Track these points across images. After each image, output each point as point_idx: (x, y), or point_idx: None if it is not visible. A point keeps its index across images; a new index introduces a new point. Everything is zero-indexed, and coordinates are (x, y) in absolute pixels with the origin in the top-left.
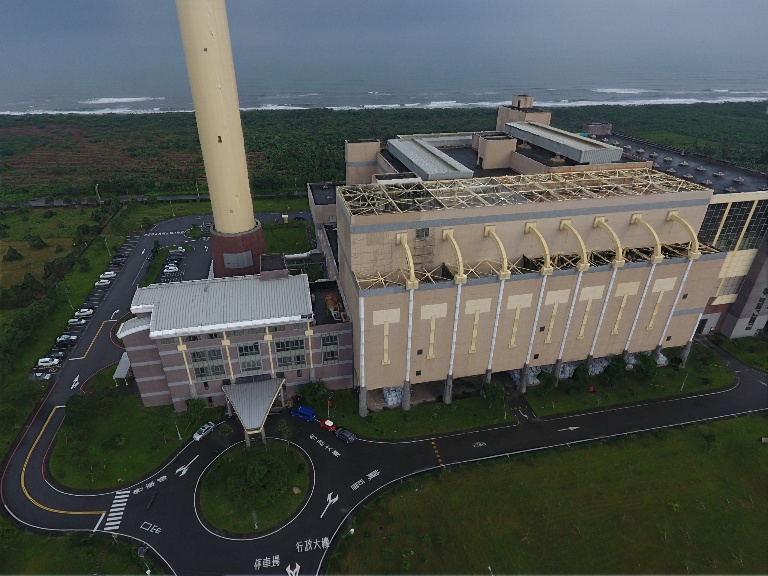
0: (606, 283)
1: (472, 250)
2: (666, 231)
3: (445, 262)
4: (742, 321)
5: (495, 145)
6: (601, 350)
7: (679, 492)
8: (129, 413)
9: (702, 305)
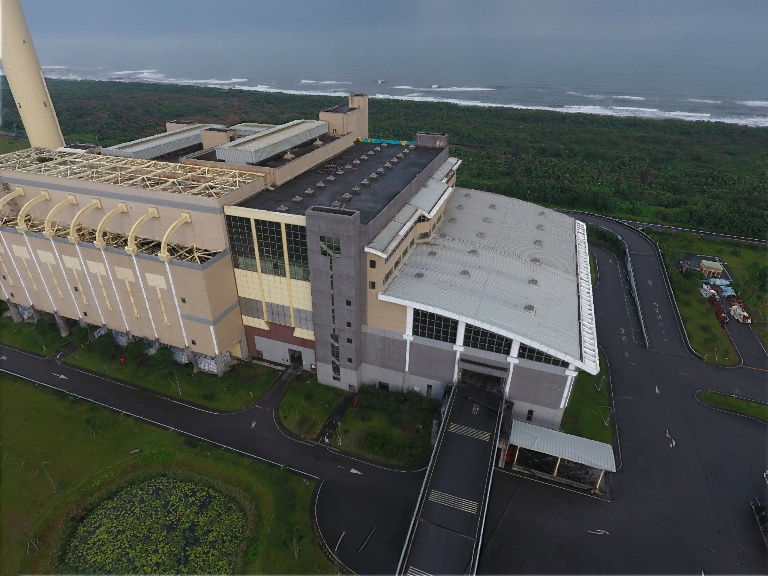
0: (103, 262)
1: (43, 209)
2: (190, 233)
3: (31, 214)
4: (322, 366)
5: (208, 135)
6: (136, 329)
7: (19, 442)
8: None
9: (208, 317)
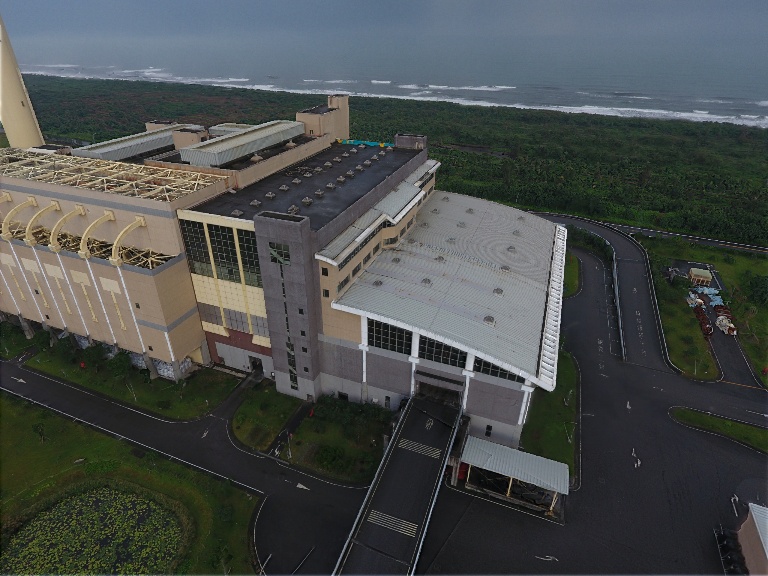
0: (59, 265)
1: (6, 210)
2: (146, 237)
3: None
4: (280, 374)
5: (180, 136)
6: (95, 334)
7: None
8: None
9: (162, 323)
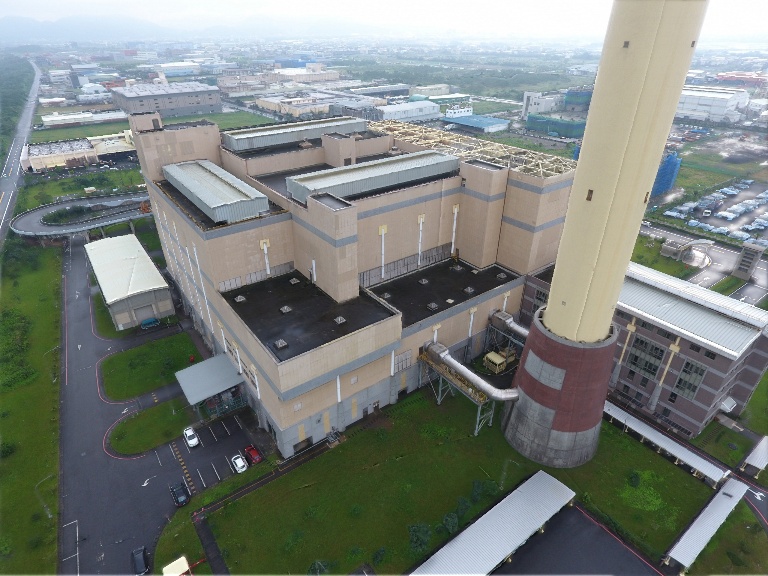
0: None
1: None
2: None
3: None
4: None
5: None
6: None
7: None
8: (763, 415)
9: None
